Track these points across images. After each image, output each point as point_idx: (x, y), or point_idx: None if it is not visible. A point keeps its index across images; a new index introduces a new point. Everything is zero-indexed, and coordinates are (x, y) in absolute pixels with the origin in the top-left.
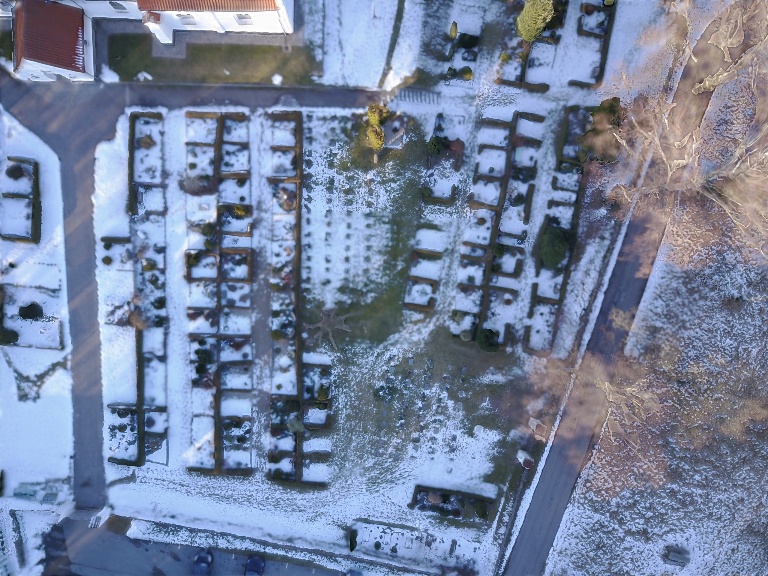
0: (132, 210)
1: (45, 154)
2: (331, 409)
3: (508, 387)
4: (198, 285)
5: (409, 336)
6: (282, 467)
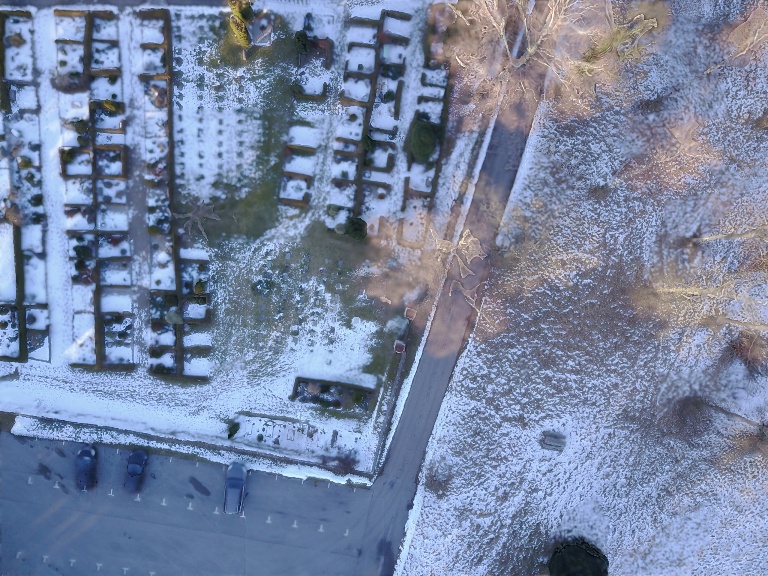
0: (4, 107)
1: None
2: (210, 304)
3: (384, 279)
4: (74, 182)
5: (285, 231)
6: (164, 362)
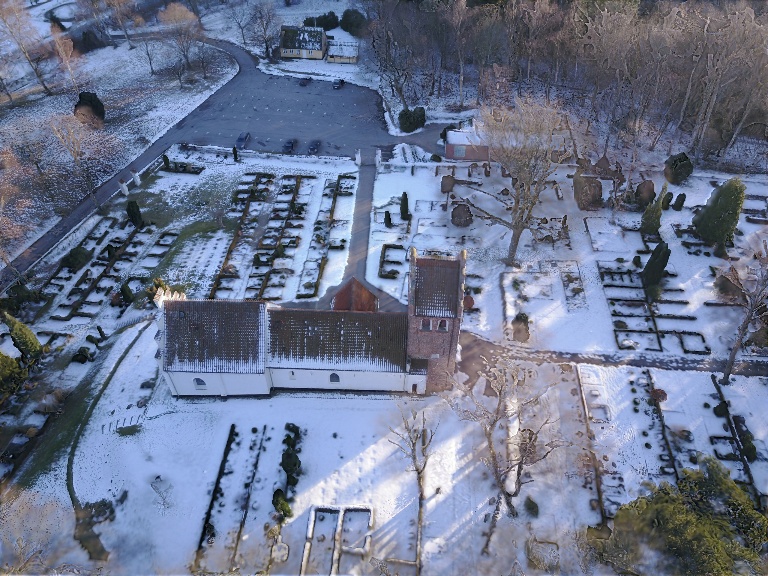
0: None
1: (373, 280)
2: None
3: None
4: None
5: (181, 224)
6: None
